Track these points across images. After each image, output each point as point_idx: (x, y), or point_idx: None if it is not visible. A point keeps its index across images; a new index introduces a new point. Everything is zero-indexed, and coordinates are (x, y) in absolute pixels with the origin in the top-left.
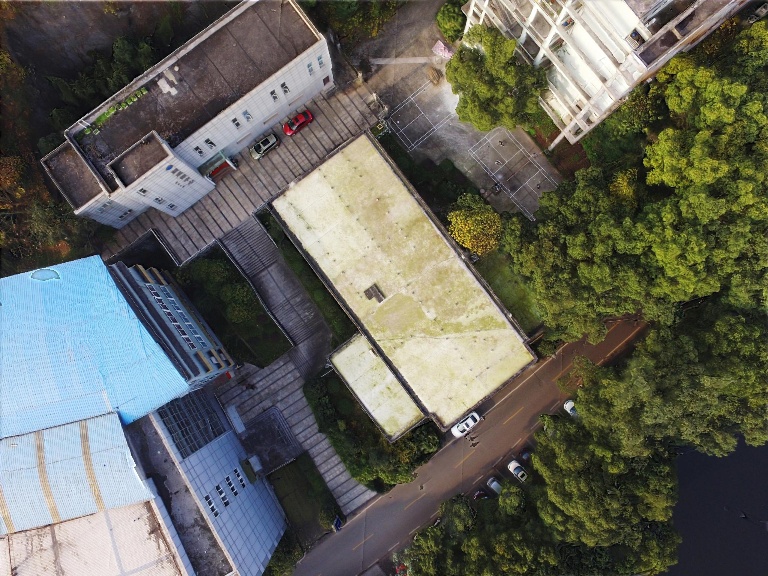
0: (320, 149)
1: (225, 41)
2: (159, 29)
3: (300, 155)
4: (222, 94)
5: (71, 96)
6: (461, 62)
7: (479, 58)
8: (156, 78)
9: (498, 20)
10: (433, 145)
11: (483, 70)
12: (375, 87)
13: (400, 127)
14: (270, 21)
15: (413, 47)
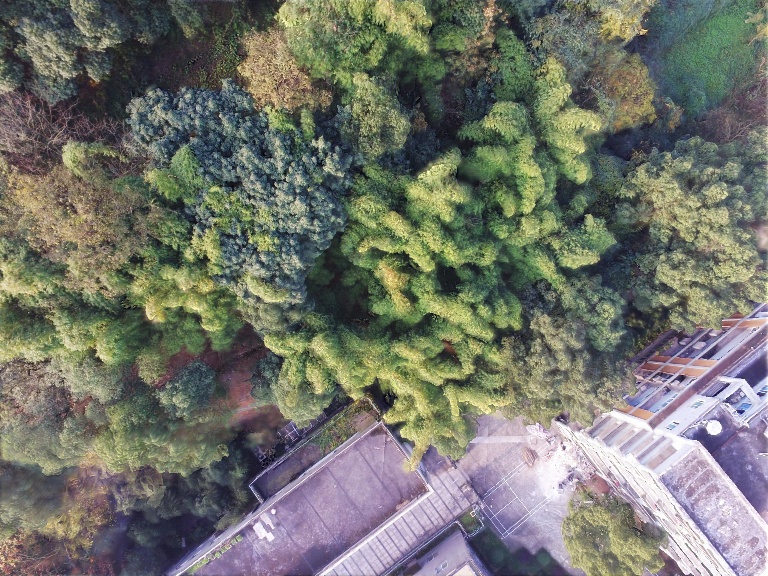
0: (409, 535)
1: (325, 482)
2: (250, 445)
3: (388, 541)
4: (322, 541)
5: (156, 519)
6: (584, 543)
7: (602, 533)
8: (252, 522)
9: (615, 470)
10: (528, 532)
11: (606, 548)
12: (467, 468)
13: (493, 512)
14: (373, 460)
15: (507, 425)
